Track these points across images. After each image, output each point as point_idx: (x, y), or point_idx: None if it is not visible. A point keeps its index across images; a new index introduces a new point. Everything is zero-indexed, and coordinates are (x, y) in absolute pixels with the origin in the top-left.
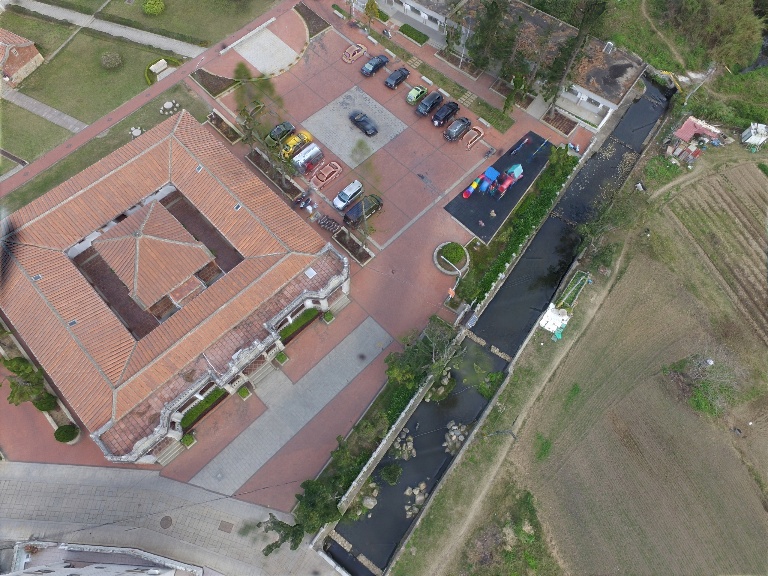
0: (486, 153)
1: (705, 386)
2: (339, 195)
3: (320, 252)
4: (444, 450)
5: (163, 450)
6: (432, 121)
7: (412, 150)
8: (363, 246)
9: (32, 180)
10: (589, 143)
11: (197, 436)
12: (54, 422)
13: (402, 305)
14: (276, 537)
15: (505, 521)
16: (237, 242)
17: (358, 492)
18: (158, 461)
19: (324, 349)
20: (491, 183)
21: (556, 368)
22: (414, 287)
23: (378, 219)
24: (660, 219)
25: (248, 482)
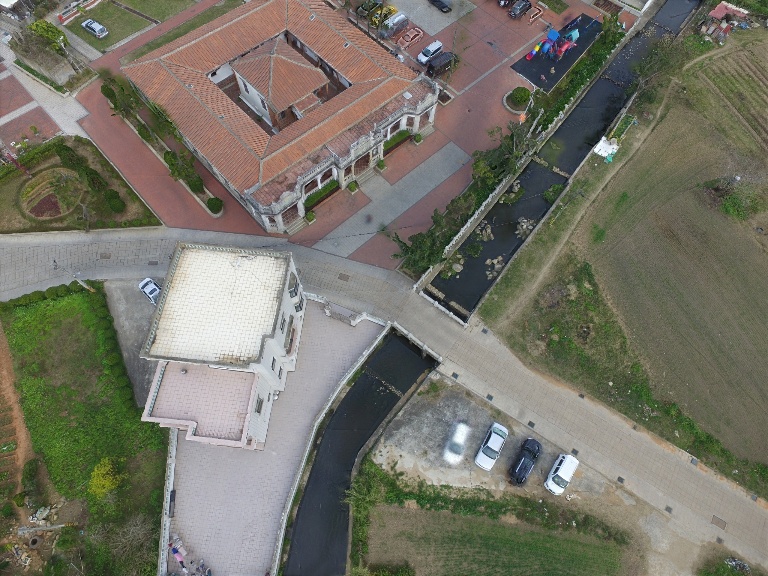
0: (545, 27)
1: (733, 198)
2: (423, 51)
3: (415, 79)
4: (516, 236)
5: (291, 223)
6: (498, 2)
7: (481, 24)
8: (444, 89)
9: (165, 35)
10: (633, 24)
11: (316, 217)
12: (201, 201)
13: (478, 134)
14: (384, 285)
15: (569, 281)
16: (346, 72)
17: (448, 260)
18: (287, 231)
19: (415, 162)
20: (552, 45)
21: (608, 182)
22: (487, 122)
23: (455, 73)
24: (695, 81)
25: (359, 249)
